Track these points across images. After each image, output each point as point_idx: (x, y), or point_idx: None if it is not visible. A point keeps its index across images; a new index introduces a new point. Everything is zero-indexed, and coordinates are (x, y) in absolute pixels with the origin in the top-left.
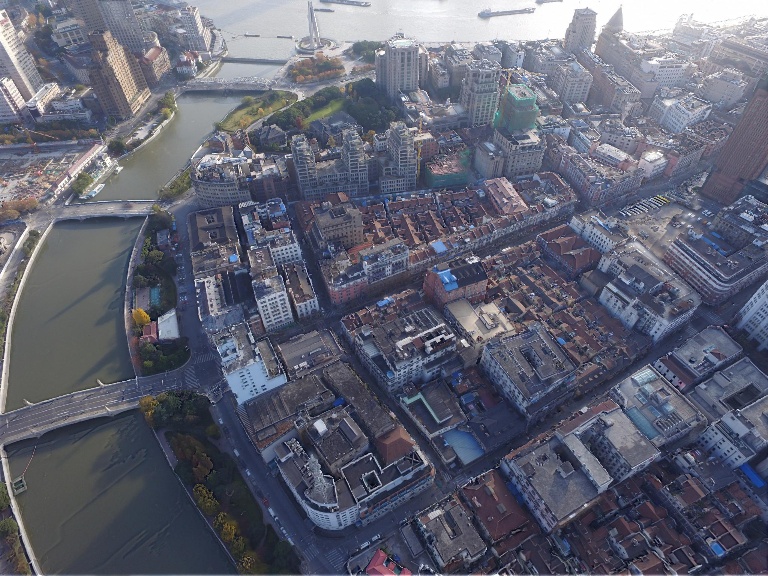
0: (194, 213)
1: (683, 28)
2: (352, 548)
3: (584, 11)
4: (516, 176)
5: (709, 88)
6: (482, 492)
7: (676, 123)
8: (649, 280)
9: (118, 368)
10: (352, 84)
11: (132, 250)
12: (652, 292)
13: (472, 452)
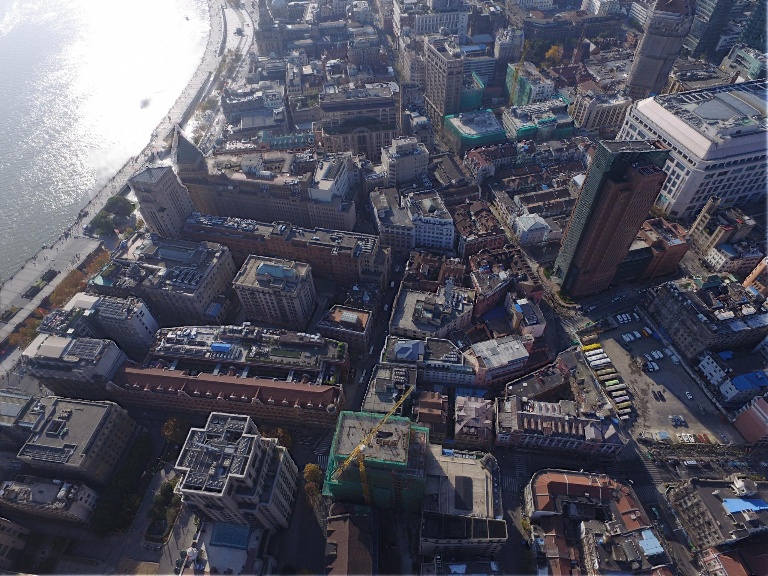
0: None
1: (235, 106)
2: None
3: (151, 176)
4: None
5: (396, 171)
6: None
7: (438, 237)
8: None
9: None
10: None
11: None
12: None
13: None
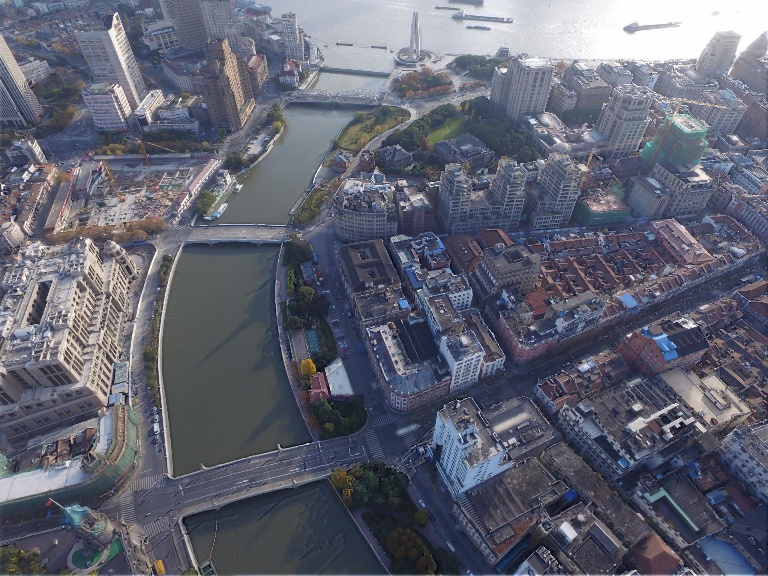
0: (345, 246)
1: None
2: None
3: (728, 33)
4: (677, 216)
5: None
6: None
7: None
8: None
9: (289, 427)
10: (468, 102)
11: (275, 283)
12: None
13: (741, 570)
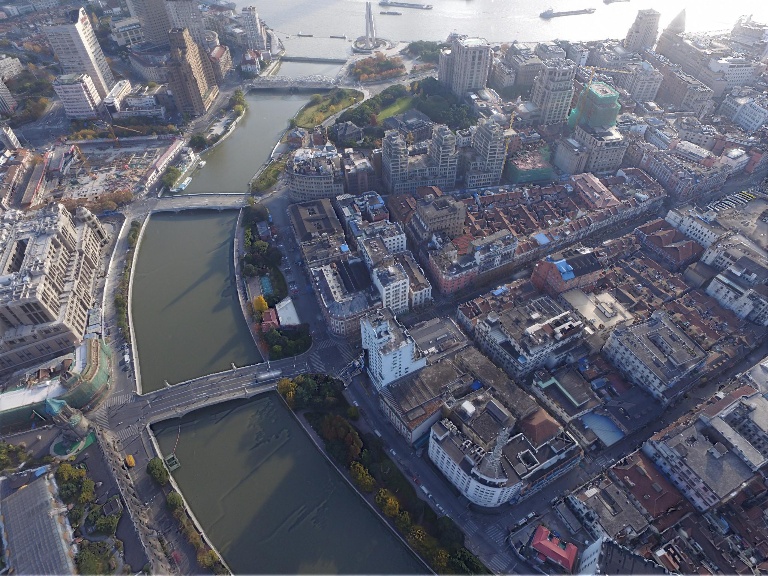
0: (295, 205)
1: (742, 29)
2: (510, 524)
3: (649, 11)
4: (597, 172)
5: None
6: (634, 472)
7: (750, 121)
8: (761, 271)
9: (244, 353)
10: (417, 82)
11: (234, 241)
12: (763, 283)
13: (613, 434)
